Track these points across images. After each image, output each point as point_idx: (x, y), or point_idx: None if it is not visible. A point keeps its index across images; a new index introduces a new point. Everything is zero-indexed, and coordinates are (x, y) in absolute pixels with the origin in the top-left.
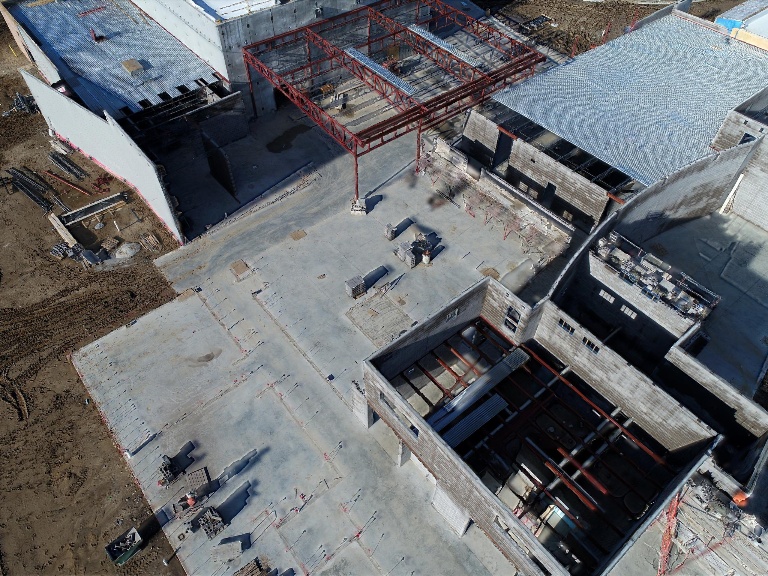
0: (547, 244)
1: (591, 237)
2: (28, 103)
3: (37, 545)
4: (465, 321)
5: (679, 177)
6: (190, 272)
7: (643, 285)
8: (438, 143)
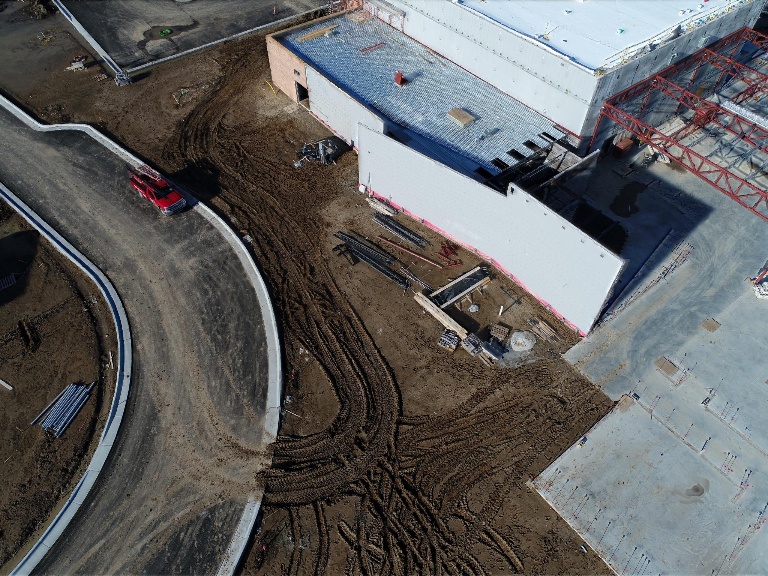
0: None
1: None
2: None
3: None
4: None
5: None
6: (613, 372)
7: None
8: None
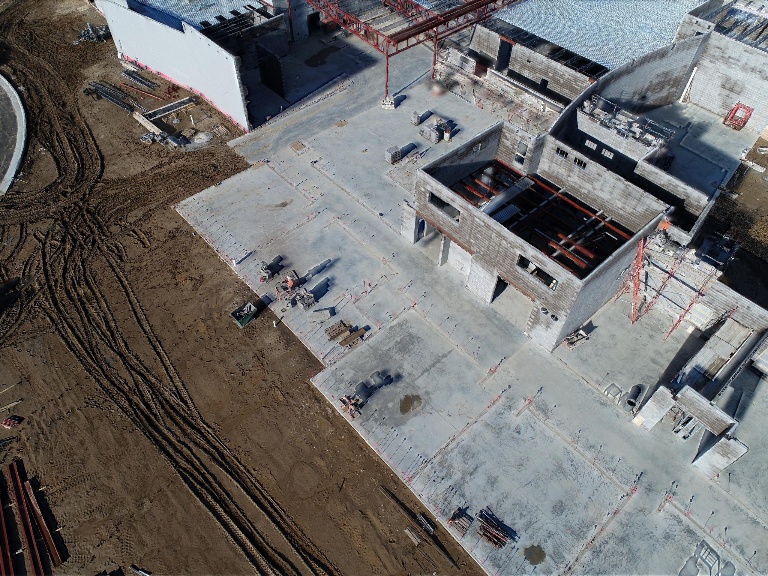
0: (543, 121)
1: (578, 97)
2: (95, 33)
3: (176, 320)
4: (485, 160)
5: (645, 61)
6: (258, 150)
7: None
8: (450, 52)
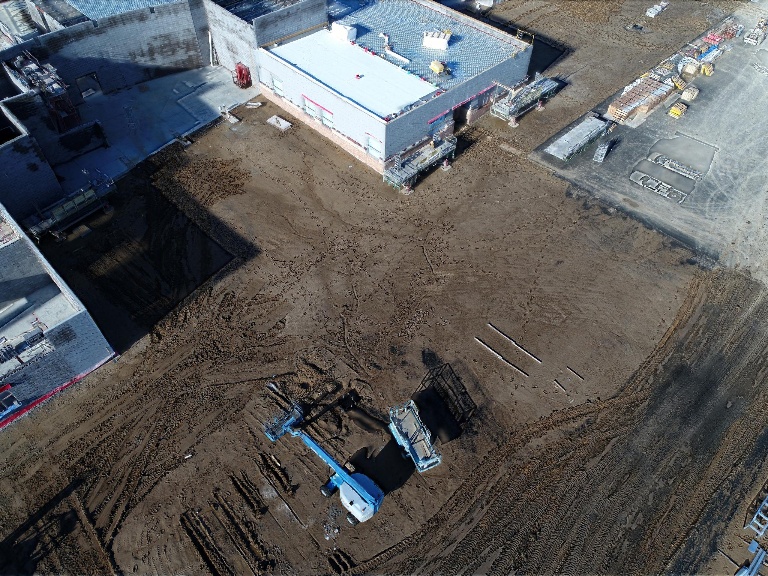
0: None
1: None
2: None
3: None
4: None
5: (116, 23)
6: None
7: (31, 81)
8: None
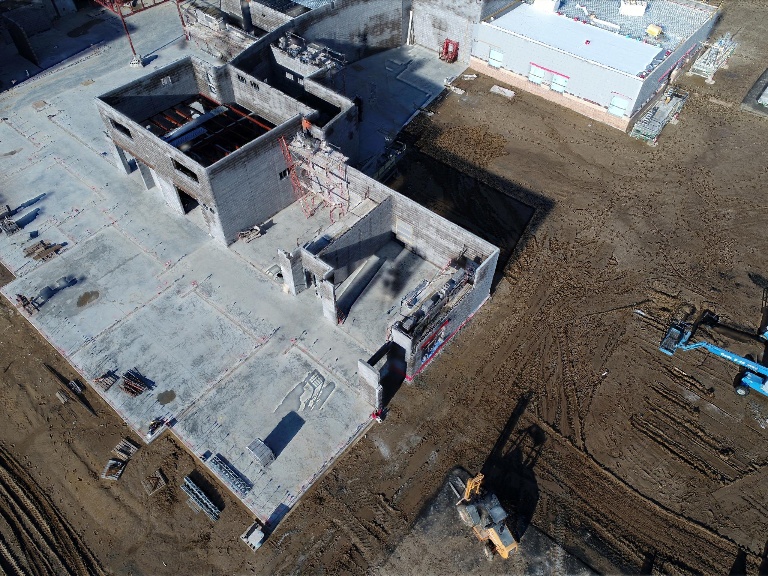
0: None
1: None
2: None
3: None
4: (185, 94)
5: (347, 4)
6: None
7: None
8: (197, 14)
